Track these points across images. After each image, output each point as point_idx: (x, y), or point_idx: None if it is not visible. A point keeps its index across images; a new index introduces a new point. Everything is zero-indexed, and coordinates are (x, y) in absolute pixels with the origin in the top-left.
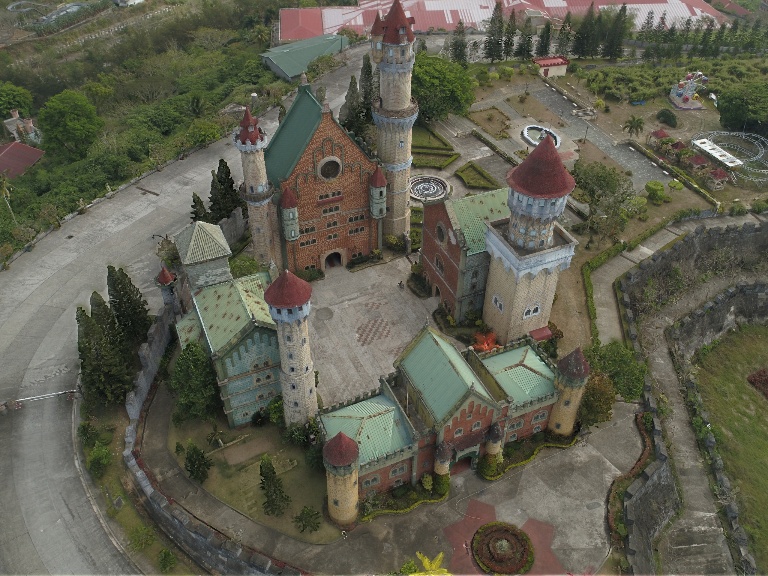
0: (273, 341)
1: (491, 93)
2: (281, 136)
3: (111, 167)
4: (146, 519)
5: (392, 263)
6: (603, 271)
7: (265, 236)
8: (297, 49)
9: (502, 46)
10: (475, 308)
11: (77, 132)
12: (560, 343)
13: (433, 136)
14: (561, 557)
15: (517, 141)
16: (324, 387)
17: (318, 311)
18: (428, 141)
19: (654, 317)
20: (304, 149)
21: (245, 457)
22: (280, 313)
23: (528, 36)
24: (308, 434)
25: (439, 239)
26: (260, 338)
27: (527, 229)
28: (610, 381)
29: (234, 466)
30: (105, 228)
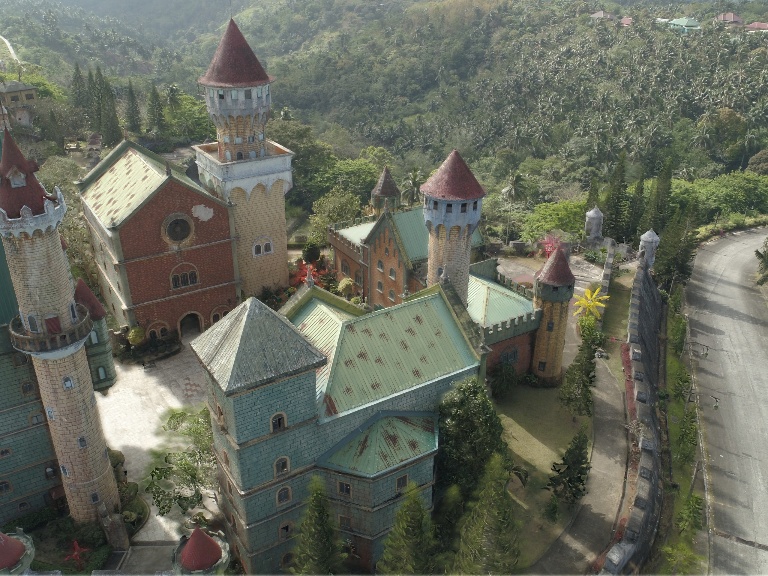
0: None
1: None
2: None
3: None
4: (652, 569)
5: None
6: None
7: None
8: None
9: None
10: None
11: None
12: None
13: None
14: (516, 275)
15: None
16: None
17: None
18: None
19: None
20: None
21: None
22: None
23: None
24: None
25: (178, 240)
26: None
27: None
28: None
29: (531, 474)
30: None
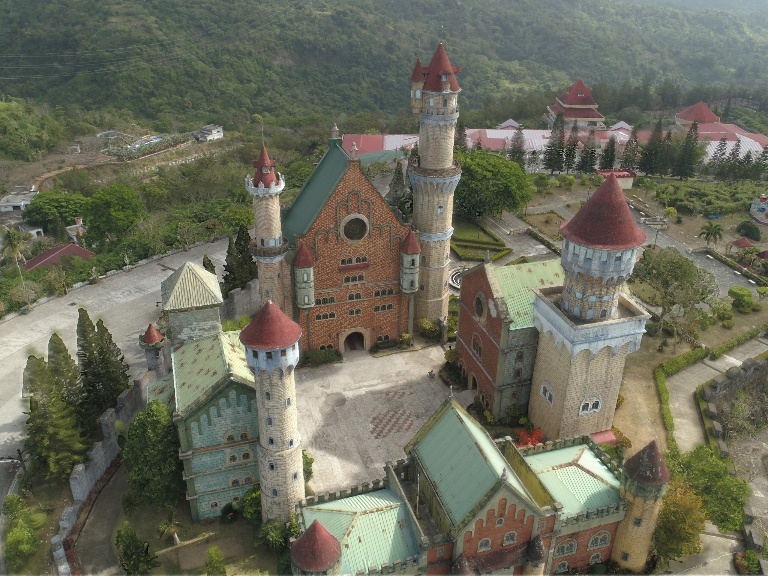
0: (254, 406)
1: (550, 199)
2: (305, 194)
3: (141, 250)
4: None
5: (424, 351)
6: (680, 378)
7: (275, 301)
8: None
9: (563, 157)
10: (519, 403)
11: (120, 222)
12: (627, 454)
13: (483, 232)
14: None
15: None
16: (321, 483)
17: (329, 396)
18: (477, 236)
19: (749, 437)
20: (326, 201)
21: (204, 561)
22: (257, 357)
23: (591, 149)
24: (287, 536)
25: (477, 314)
26: (237, 399)
27: (585, 293)
28: (697, 497)
29: (187, 571)
30: (113, 298)
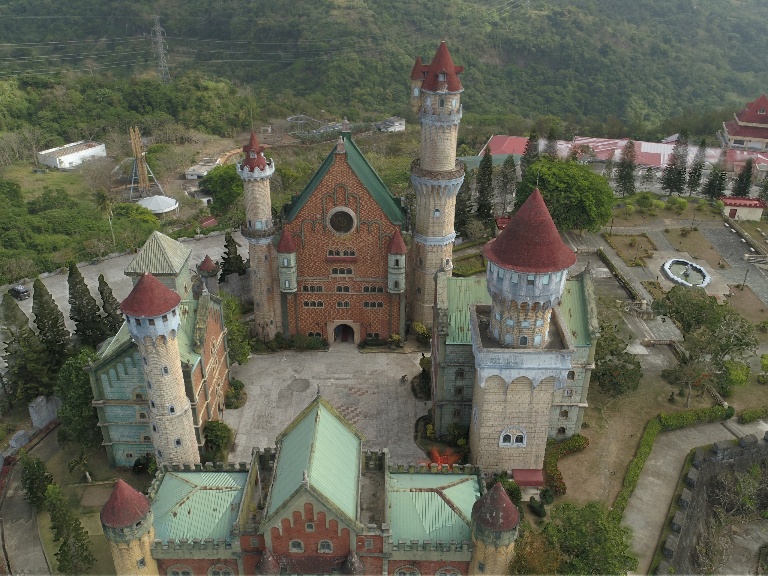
0: None
1: (650, 221)
2: (312, 183)
3: None
4: None
5: (411, 355)
6: (683, 435)
7: (262, 282)
8: (472, 160)
9: (685, 178)
10: (462, 422)
11: None
12: (559, 501)
13: None
14: None
15: (652, 271)
16: (239, 458)
17: (295, 380)
18: None
19: (738, 517)
20: (312, 191)
21: (101, 502)
22: (130, 322)
23: (721, 172)
24: None
25: None
26: None
27: (502, 315)
28: (557, 557)
29: (83, 507)
30: None
